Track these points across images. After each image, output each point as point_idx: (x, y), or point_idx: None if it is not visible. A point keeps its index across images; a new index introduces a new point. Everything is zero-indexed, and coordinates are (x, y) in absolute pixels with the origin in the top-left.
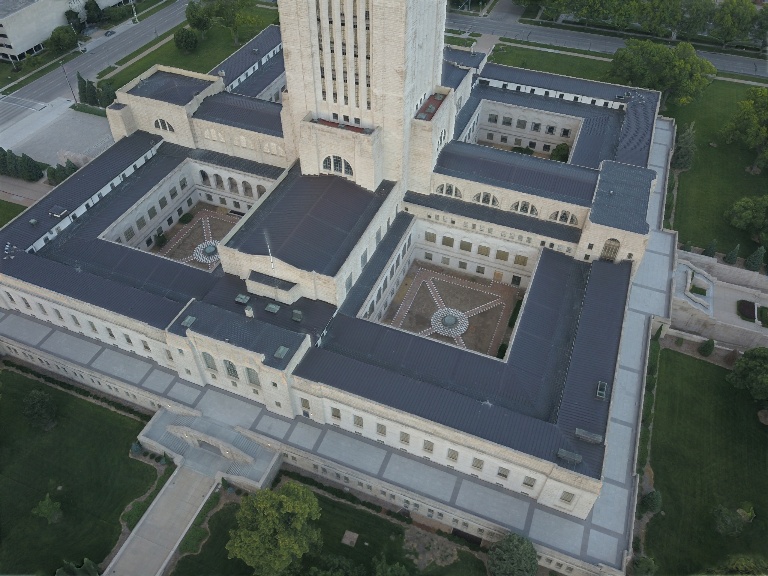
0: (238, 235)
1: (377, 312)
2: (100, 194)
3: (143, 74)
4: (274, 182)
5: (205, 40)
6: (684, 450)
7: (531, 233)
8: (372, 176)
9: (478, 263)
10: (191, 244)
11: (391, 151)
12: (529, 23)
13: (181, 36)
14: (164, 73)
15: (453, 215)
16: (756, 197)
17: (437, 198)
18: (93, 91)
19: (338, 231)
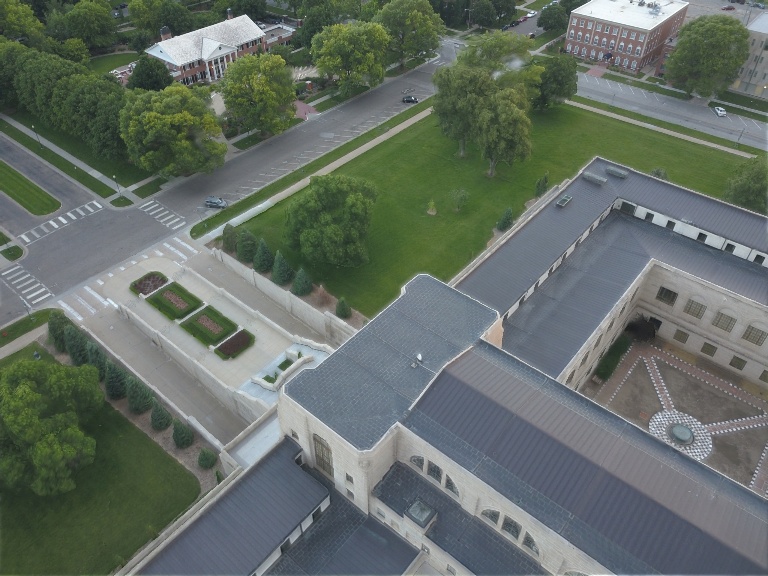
0: None
1: None
2: None
3: None
4: None
5: None
6: (446, 250)
7: None
8: None
9: None
10: None
11: None
12: None
13: None
14: None
15: None
16: (2, 464)
17: None
18: None
19: None
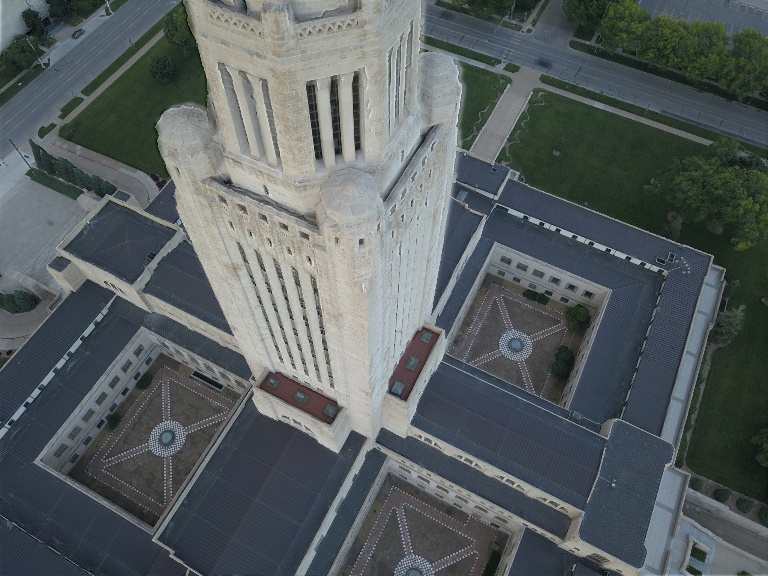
0: (179, 513)
1: (334, 574)
2: (41, 385)
3: (90, 213)
4: (226, 427)
5: (187, 57)
6: None
7: (513, 515)
8: (335, 447)
9: (455, 502)
10: (147, 424)
11: (359, 422)
12: (581, 49)
13: (155, 67)
14: (116, 204)
15: (429, 472)
16: None
17: (414, 443)
18: (50, 162)
19: (289, 523)
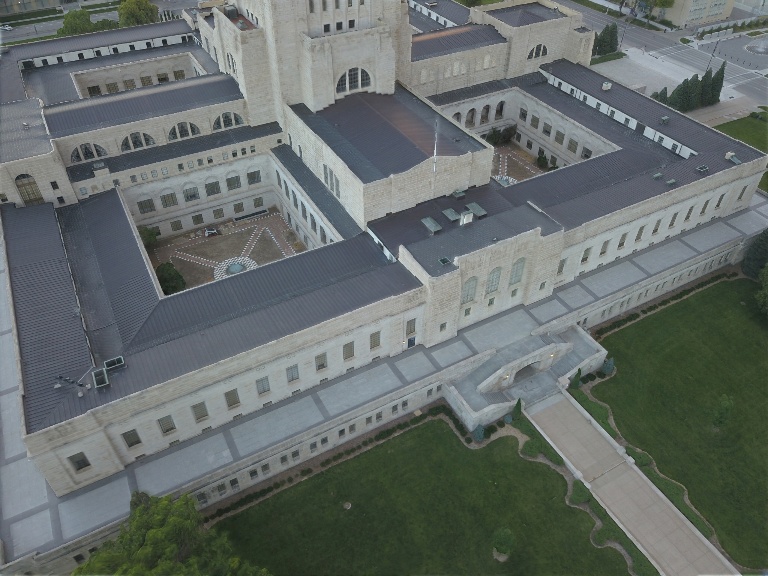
0: None
1: None
2: None
3: None
4: None
5: None
6: None
7: None
8: None
9: None
10: None
11: None
12: None
13: None
14: None
15: None
16: None
17: None
18: None
19: None
